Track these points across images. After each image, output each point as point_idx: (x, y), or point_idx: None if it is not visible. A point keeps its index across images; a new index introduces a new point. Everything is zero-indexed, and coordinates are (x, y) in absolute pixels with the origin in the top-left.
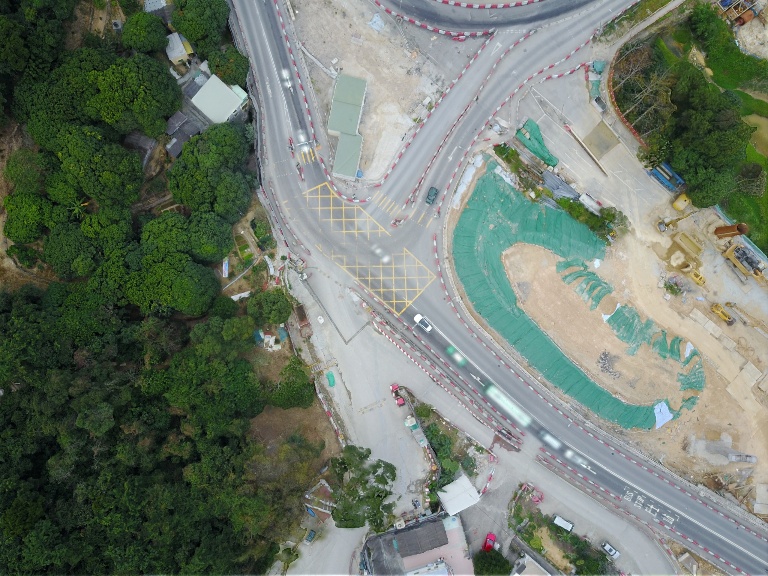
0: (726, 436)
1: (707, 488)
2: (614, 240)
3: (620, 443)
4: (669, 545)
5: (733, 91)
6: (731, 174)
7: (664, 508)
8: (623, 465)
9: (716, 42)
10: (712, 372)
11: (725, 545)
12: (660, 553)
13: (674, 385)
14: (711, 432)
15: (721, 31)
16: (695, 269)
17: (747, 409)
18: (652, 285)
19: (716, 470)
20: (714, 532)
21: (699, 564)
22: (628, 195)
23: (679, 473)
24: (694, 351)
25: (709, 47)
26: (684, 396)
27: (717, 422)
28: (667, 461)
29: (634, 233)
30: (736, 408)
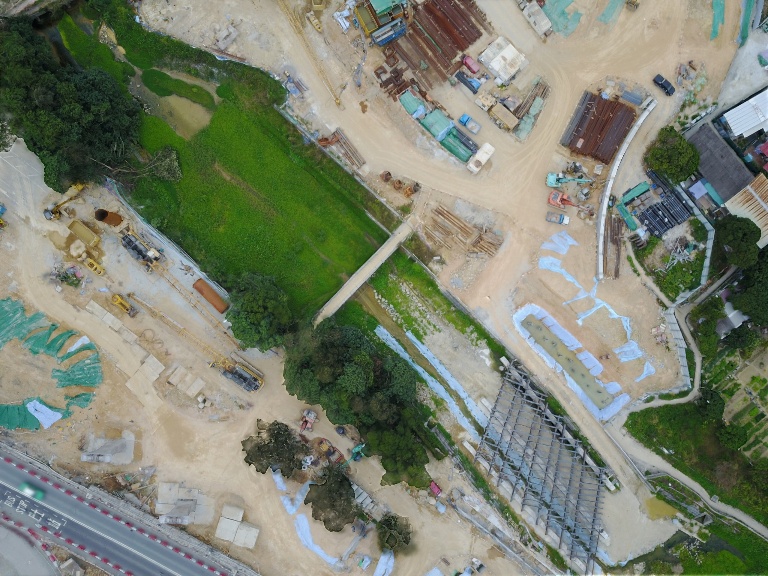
0: (128, 434)
1: (99, 489)
2: (2, 229)
3: (1, 445)
4: (54, 551)
5: (149, 70)
6: (61, 157)
7: (50, 512)
8: (5, 468)
9: (116, 18)
10: (111, 367)
11: (117, 549)
12: (44, 560)
13: (48, 382)
14: (112, 430)
15: (116, 6)
16: (96, 259)
17: (147, 405)
18: (44, 277)
19: (118, 470)
20: (105, 535)
21: (87, 570)
22: (20, 181)
23: (70, 475)
24: (88, 345)
25: (111, 24)
26: (67, 393)
27: (118, 419)
28: (58, 462)
29: (29, 222)
30: (136, 404)
